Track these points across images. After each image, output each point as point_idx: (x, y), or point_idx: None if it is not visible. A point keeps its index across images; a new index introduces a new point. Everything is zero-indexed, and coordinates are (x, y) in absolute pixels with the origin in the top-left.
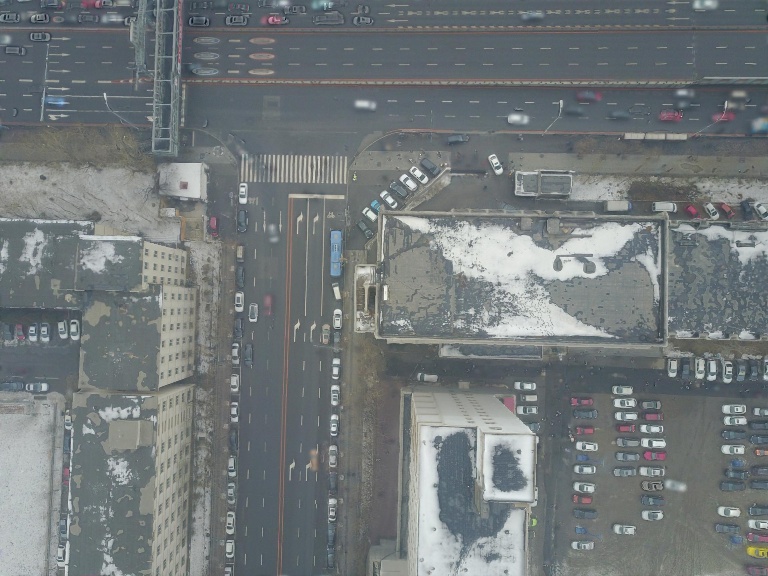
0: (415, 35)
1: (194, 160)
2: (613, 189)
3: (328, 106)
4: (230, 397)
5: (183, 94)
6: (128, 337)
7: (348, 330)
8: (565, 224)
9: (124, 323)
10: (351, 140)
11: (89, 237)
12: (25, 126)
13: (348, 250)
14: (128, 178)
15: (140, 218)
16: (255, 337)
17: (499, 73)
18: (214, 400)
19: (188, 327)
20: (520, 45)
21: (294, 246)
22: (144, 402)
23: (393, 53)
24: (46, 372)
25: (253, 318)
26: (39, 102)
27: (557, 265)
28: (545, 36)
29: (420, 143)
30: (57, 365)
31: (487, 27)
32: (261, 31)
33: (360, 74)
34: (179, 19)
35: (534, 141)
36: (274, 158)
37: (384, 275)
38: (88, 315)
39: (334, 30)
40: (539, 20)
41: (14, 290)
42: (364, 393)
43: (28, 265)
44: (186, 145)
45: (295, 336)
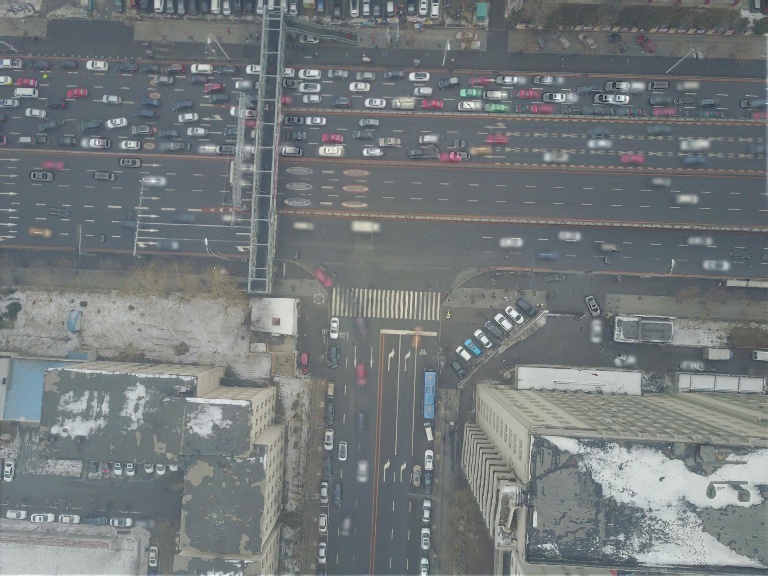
0: (512, 172)
1: (285, 293)
2: (712, 334)
3: (422, 241)
4: (317, 537)
5: (275, 225)
6: (231, 499)
7: (439, 471)
8: (719, 450)
9: (227, 484)
10: (445, 276)
11: (196, 400)
12: (113, 253)
13: (440, 389)
14: (222, 317)
15: (229, 351)
16: (344, 475)
17: (598, 214)
18: (301, 539)
19: (279, 468)
20: (620, 186)
21: (385, 382)
22: (247, 567)
23: (490, 190)
24: (130, 506)
25: (343, 457)
26: (128, 229)
27: (711, 493)
28: (646, 177)
29: (515, 281)
30: (141, 499)
31: (587, 167)
32: (355, 163)
33: (455, 210)
34: (276, 155)
35: (632, 283)
36: (366, 292)
37: (531, 496)
38: (190, 475)
39: (430, 164)
40: (640, 162)
41: (114, 445)
42: (455, 537)
43: (129, 420)
44: (276, 277)
45: (385, 475)
